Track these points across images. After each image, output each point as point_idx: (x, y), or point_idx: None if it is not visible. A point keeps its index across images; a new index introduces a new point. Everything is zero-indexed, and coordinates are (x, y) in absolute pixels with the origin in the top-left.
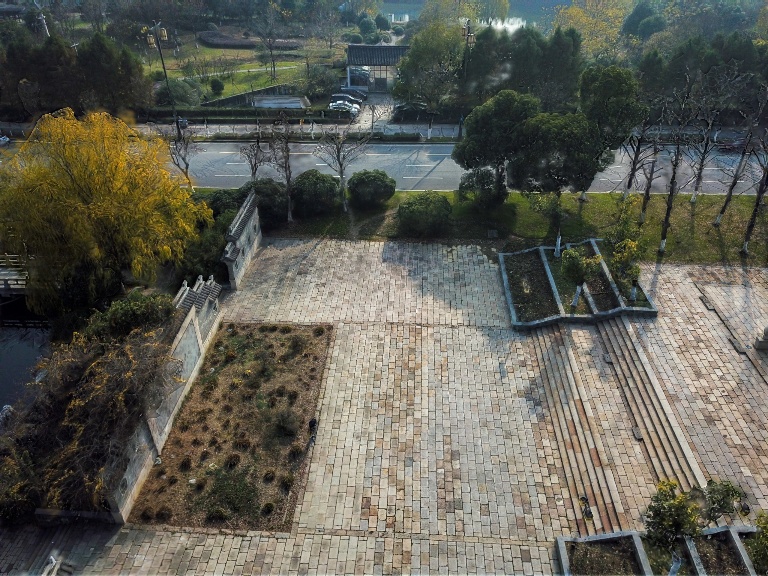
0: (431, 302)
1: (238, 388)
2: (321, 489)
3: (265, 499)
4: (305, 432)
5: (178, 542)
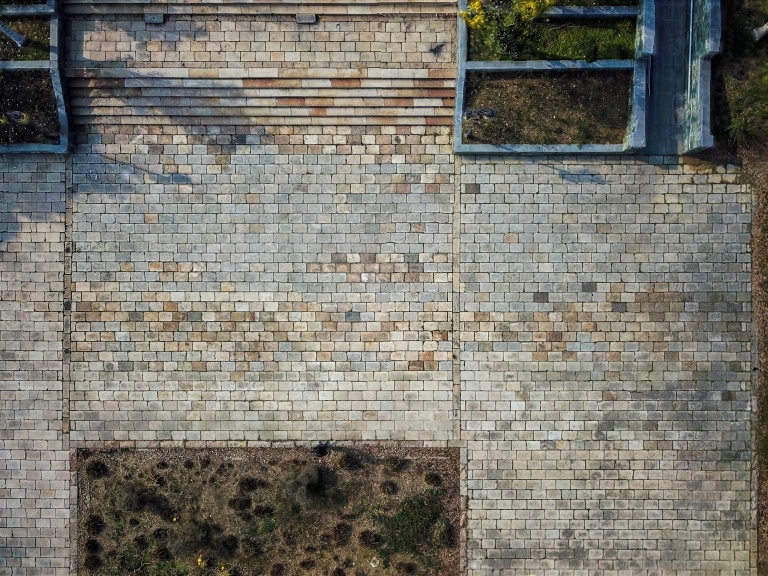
0: (1, 286)
1: (236, 568)
2: (401, 422)
3: (419, 486)
4: (311, 456)
5: (480, 570)
